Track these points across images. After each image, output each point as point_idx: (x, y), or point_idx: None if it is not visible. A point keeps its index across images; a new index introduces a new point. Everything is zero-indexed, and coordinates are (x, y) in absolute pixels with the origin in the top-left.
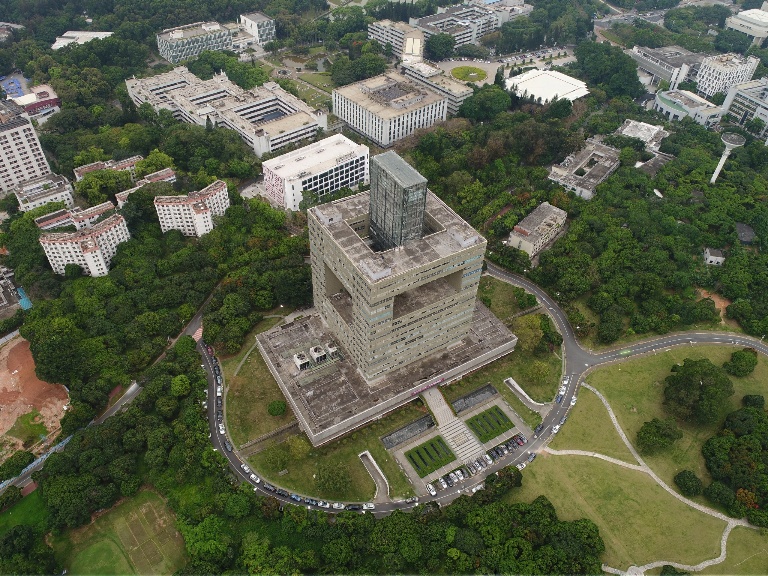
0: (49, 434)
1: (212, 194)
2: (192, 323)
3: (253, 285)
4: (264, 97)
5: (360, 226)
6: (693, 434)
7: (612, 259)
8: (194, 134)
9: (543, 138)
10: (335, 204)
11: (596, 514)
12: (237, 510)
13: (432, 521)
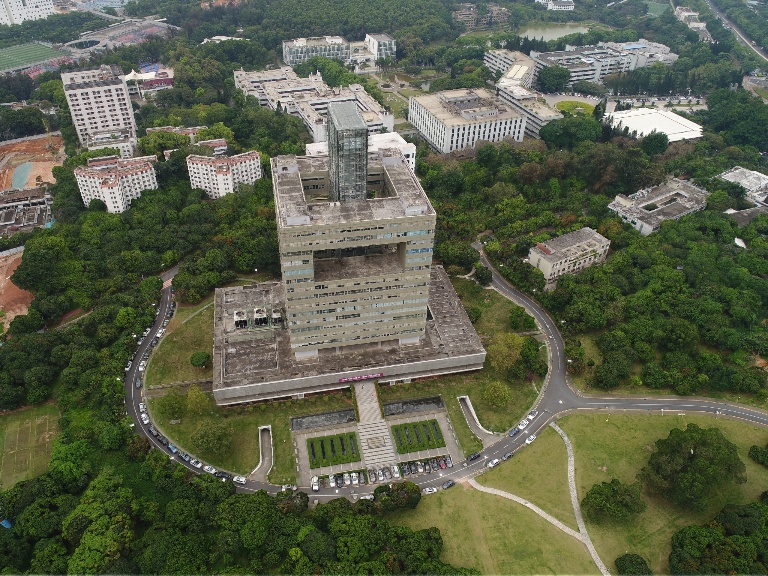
0: (2, 333)
1: (241, 161)
2: (173, 270)
3: (241, 247)
4: (344, 96)
5: (319, 184)
6: (670, 517)
7: (646, 299)
8: (261, 115)
9: (614, 164)
10: (302, 159)
11: (495, 570)
12: (106, 440)
13: (293, 513)
